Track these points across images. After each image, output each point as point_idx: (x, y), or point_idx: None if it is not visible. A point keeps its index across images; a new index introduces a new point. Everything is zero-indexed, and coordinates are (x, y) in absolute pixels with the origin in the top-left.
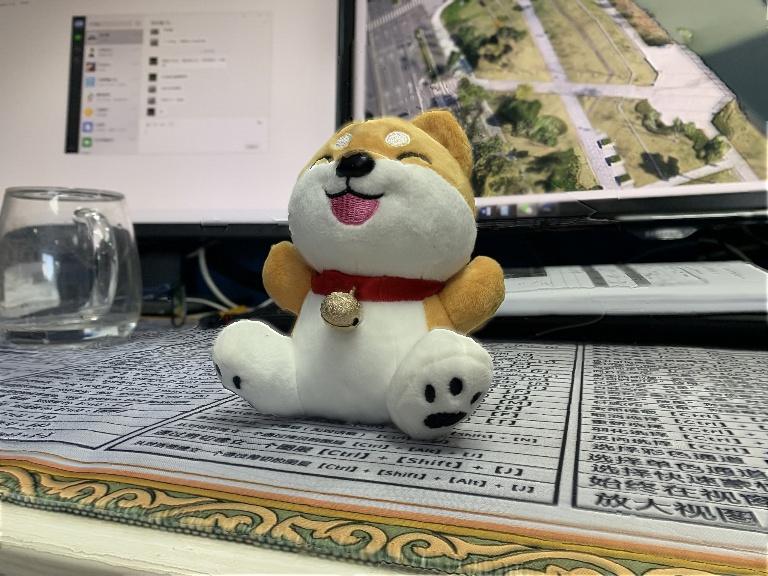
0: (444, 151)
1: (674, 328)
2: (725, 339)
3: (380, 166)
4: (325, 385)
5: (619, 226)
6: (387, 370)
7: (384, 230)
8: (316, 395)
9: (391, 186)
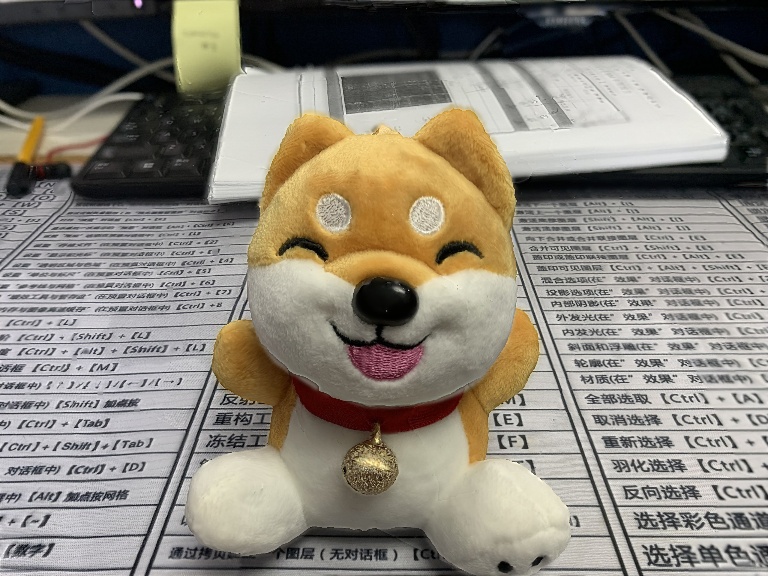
0: (484, 207)
1: (595, 181)
2: (638, 185)
3: (427, 302)
4: (346, 521)
5: (517, 9)
6: (427, 506)
7: (432, 380)
8: (332, 525)
9: (441, 324)
